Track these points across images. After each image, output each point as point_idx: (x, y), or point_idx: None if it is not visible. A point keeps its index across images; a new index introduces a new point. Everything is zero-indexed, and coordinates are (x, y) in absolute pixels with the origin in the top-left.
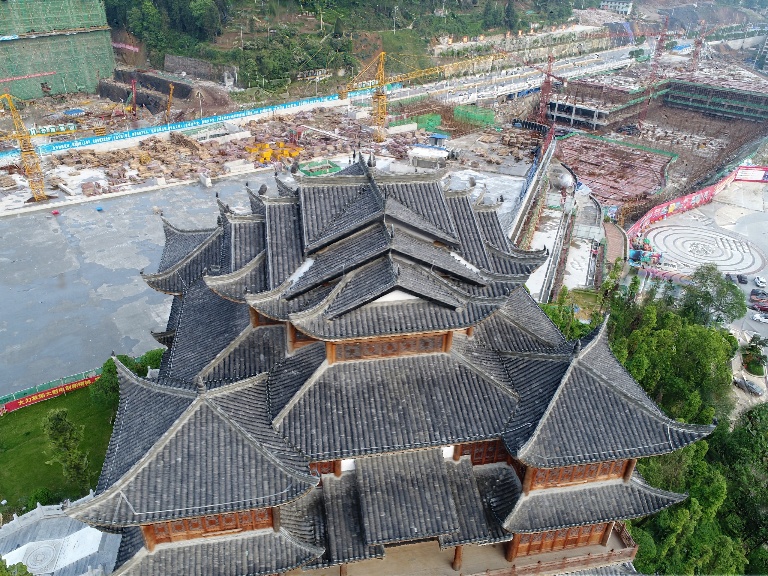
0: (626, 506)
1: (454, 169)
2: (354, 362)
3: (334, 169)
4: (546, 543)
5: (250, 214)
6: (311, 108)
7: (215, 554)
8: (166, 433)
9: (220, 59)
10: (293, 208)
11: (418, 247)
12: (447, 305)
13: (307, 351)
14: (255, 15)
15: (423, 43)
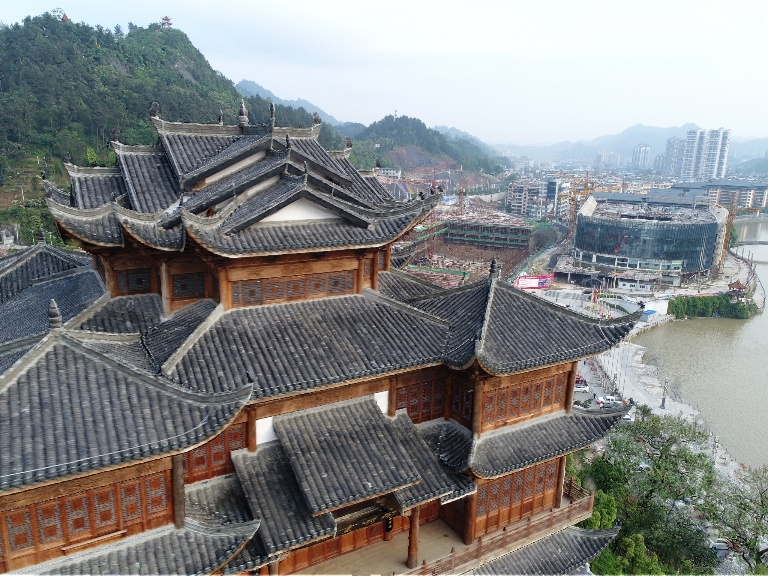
0: (577, 435)
1: None
2: (255, 307)
3: None
4: (503, 513)
5: None
6: None
7: (85, 575)
8: (2, 376)
9: None
10: (154, 158)
11: None
12: (358, 221)
13: (190, 310)
14: (38, 174)
15: None
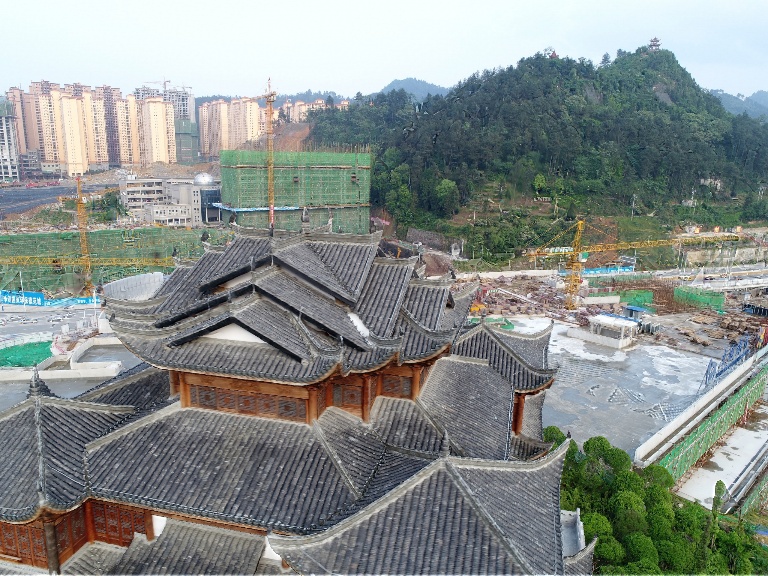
0: None
1: (645, 343)
2: (208, 411)
3: (506, 326)
4: None
5: None
6: (514, 275)
7: None
8: None
9: (452, 233)
10: None
11: (300, 295)
12: (291, 353)
13: None
14: (491, 198)
15: (664, 230)
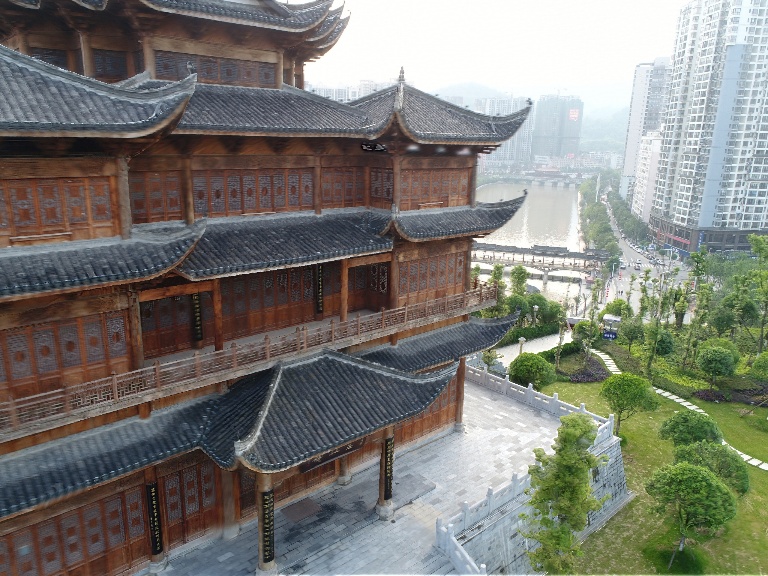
0: None
1: None
2: None
3: None
4: None
5: None
6: None
7: None
8: None
9: None
10: None
11: None
12: None
13: None
14: None
15: None
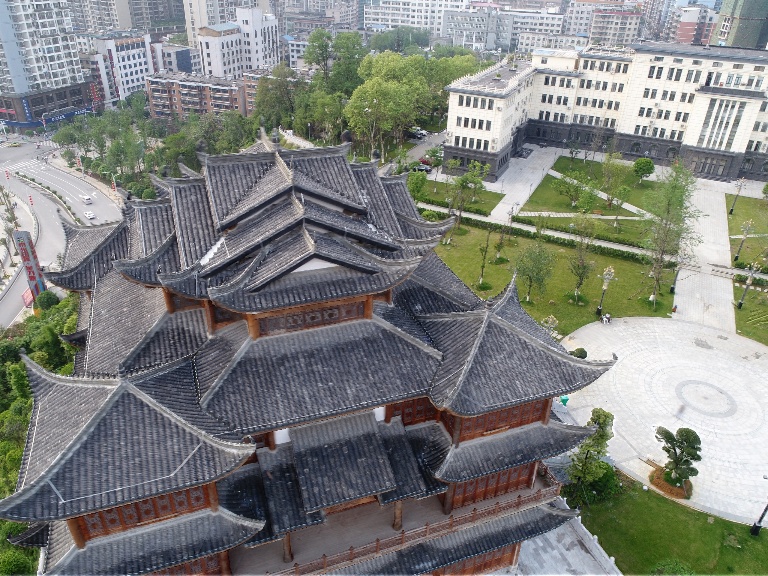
0: None
1: None
2: None
3: None
4: None
5: (388, 176)
6: None
7: None
8: None
9: None
10: None
11: None
12: None
13: None
14: None
15: None
